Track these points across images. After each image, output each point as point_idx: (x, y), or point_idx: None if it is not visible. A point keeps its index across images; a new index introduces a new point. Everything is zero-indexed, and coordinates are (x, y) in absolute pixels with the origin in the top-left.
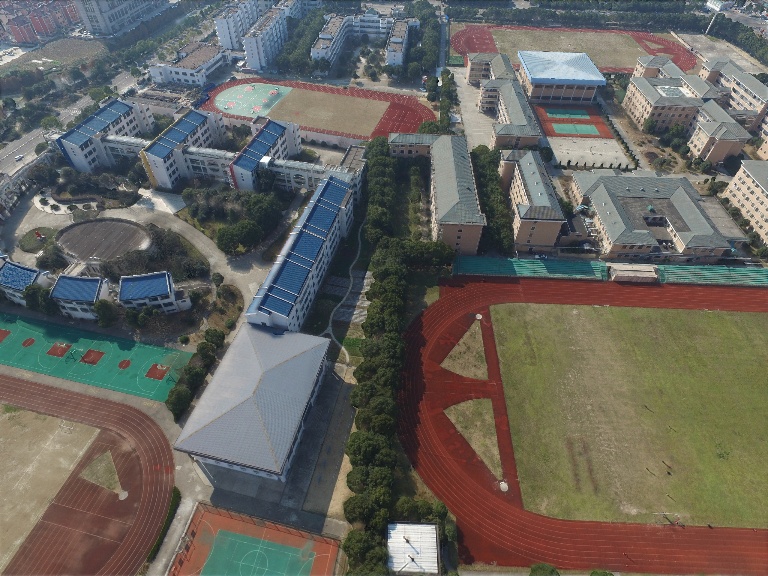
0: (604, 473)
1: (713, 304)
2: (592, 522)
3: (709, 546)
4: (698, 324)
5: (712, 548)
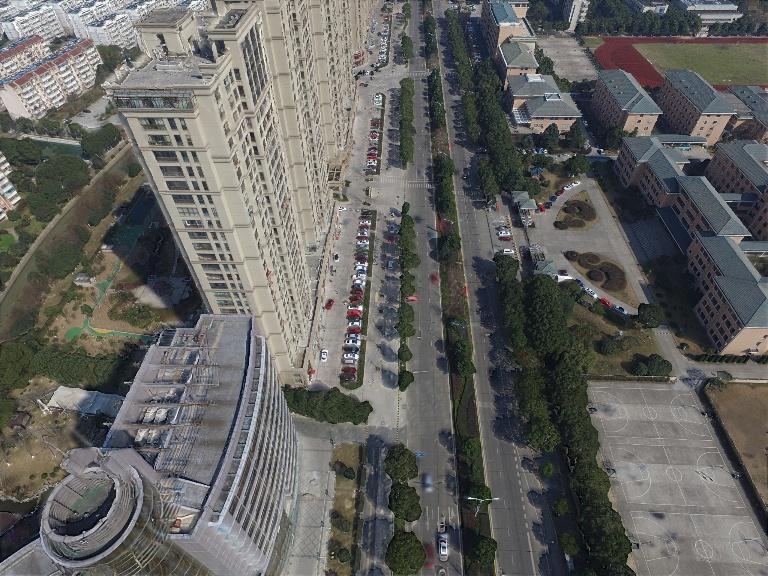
0: (765, 49)
1: (723, 87)
2: (766, 43)
3: (724, 41)
4: (732, 80)
5: (723, 41)
